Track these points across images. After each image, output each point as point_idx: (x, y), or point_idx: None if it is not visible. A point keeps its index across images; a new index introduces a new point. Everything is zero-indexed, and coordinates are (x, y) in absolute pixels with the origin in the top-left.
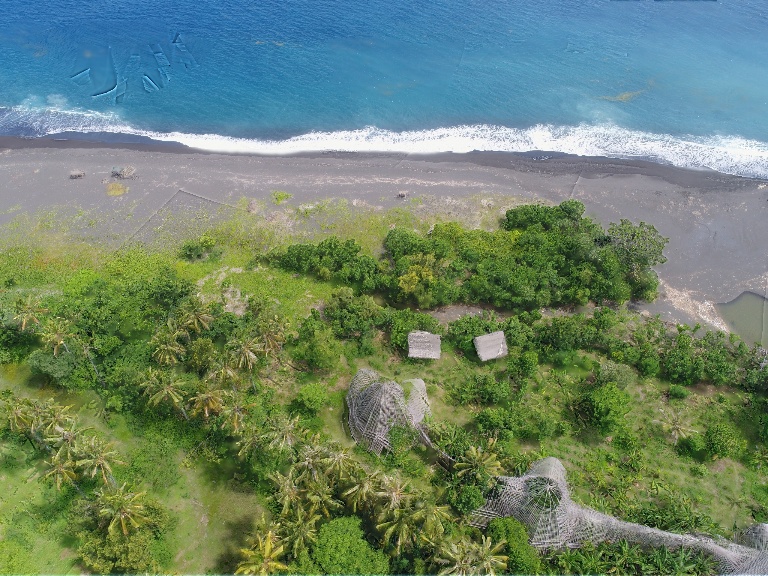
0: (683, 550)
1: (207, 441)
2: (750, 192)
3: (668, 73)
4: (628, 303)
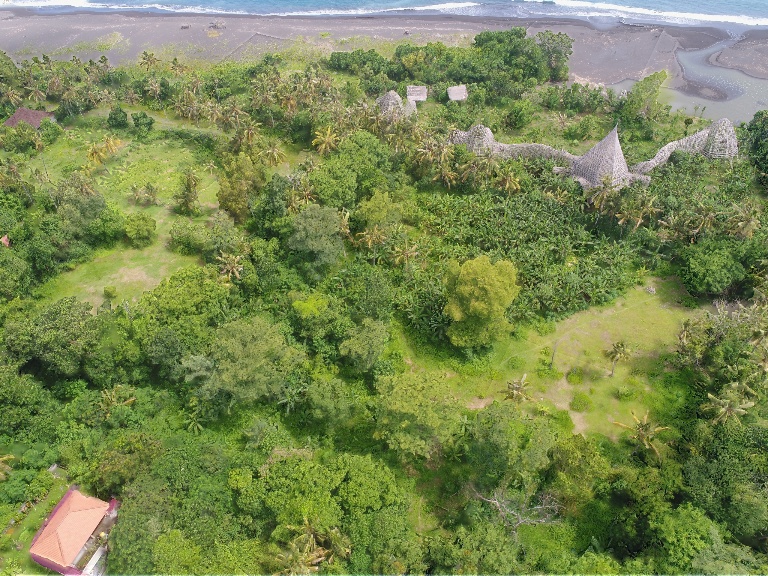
0: (552, 158)
1: (286, 136)
2: (645, 33)
3: None
4: (549, 83)
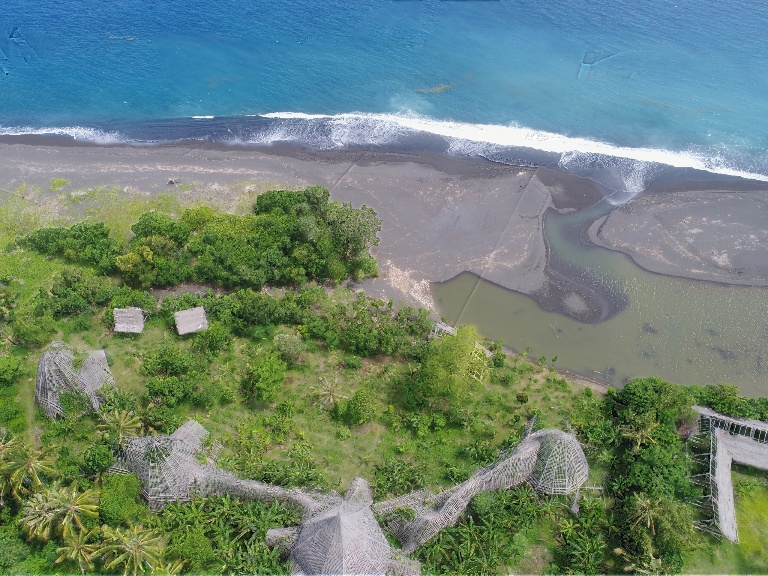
0: (276, 501)
1: None
2: (508, 179)
3: (462, 66)
4: (349, 282)
